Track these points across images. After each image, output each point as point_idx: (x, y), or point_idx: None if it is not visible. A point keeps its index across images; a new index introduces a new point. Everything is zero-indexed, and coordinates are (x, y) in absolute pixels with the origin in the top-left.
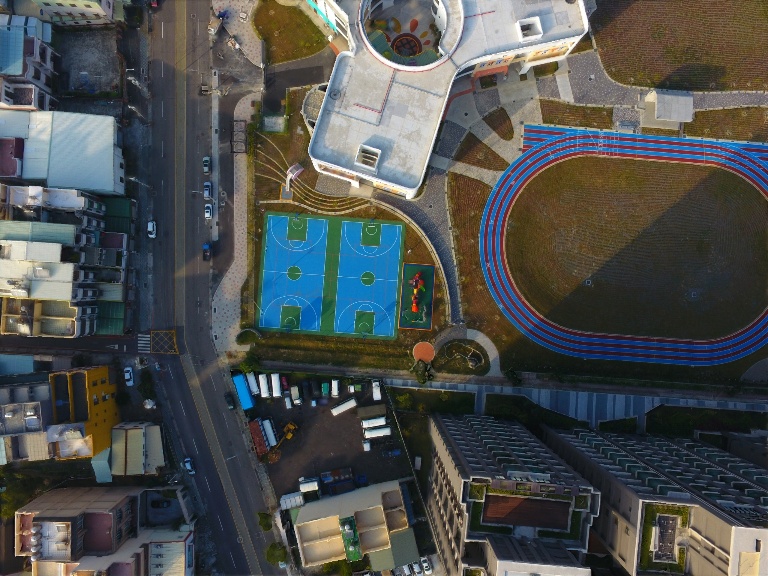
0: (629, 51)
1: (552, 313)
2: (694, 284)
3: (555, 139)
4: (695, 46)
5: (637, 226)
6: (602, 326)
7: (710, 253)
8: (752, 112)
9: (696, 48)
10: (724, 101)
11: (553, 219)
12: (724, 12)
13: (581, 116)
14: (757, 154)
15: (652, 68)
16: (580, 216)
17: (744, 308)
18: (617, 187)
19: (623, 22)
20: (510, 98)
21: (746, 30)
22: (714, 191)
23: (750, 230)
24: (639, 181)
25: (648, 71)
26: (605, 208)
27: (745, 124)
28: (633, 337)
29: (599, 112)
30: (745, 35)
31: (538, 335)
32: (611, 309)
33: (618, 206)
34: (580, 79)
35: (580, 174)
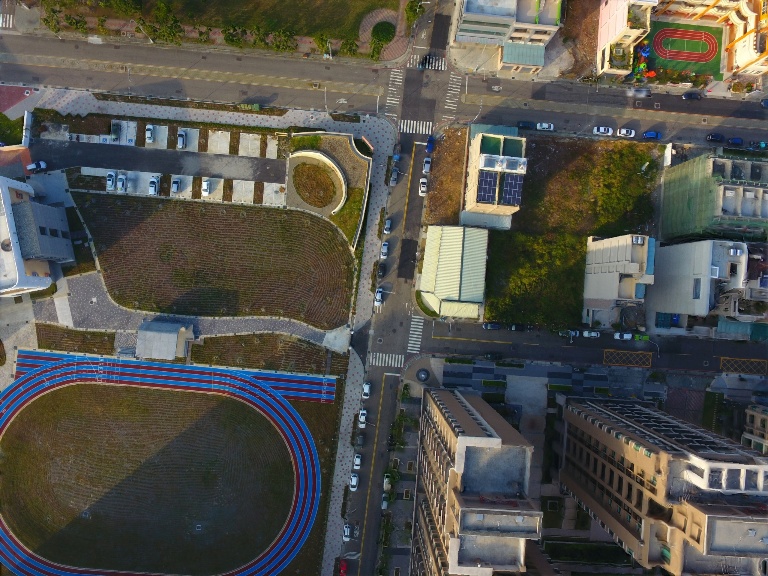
0: (135, 273)
1: (42, 548)
2: (199, 516)
3: (51, 365)
4: (206, 269)
5: (139, 456)
6: (96, 561)
7: (217, 484)
8: (266, 338)
9: (207, 271)
10: (236, 327)
11: (48, 448)
12: (239, 233)
13: (80, 341)
14: (269, 383)
15: (159, 291)
16: (78, 445)
17: (249, 542)
18: (119, 415)
19: (129, 243)
20: (3, 321)
21: (262, 253)
22: (222, 420)
23: (260, 461)
24: (142, 409)
25: (154, 295)
26: (105, 437)
27: (257, 351)
28: (128, 573)
29: (100, 337)
30: (261, 258)
31: (25, 571)
32: (109, 542)
33: (119, 435)
34: (81, 302)
35: (78, 402)
